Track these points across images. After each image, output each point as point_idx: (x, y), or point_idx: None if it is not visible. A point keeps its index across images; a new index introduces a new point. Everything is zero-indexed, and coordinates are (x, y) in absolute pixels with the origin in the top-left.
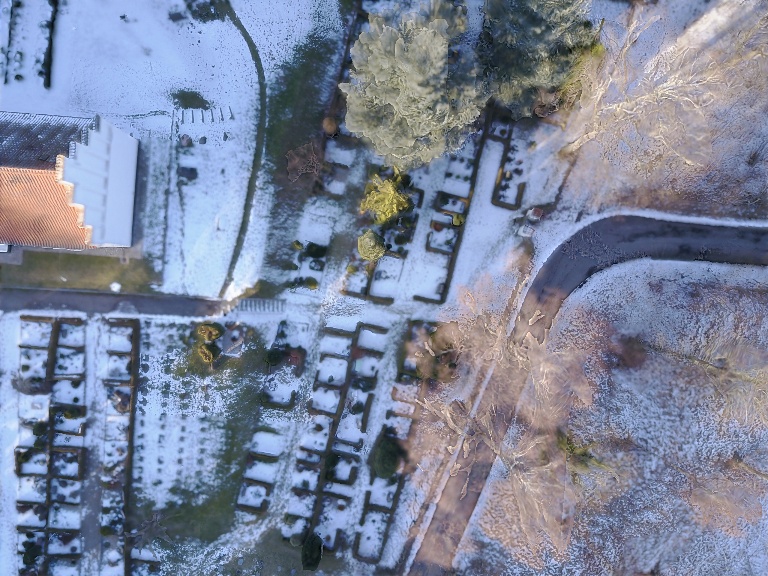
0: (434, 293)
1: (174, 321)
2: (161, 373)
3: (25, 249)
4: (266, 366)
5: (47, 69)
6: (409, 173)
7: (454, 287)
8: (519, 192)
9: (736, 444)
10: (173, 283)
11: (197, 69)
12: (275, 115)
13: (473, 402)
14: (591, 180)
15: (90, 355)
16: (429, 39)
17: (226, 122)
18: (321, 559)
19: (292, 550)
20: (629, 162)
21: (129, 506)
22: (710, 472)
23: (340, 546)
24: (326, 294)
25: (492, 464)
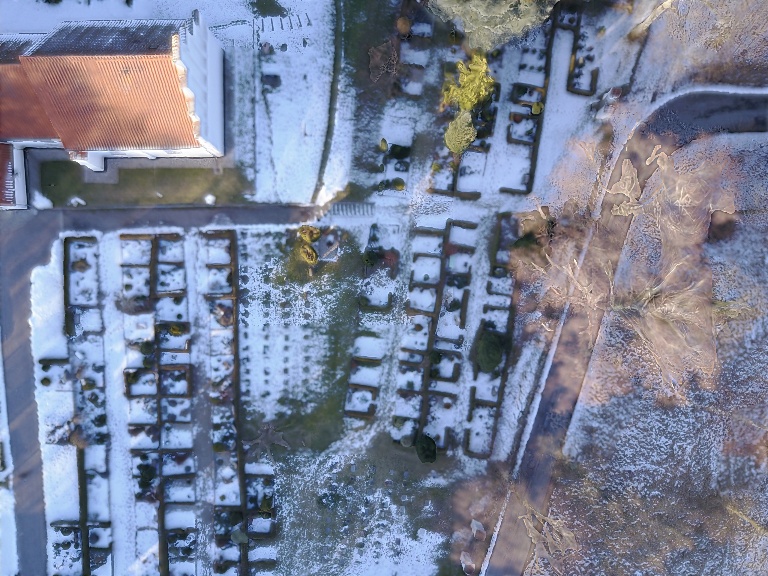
0: (519, 184)
1: (269, 230)
2: (261, 283)
3: (120, 167)
4: (362, 270)
5: None
6: None
7: (538, 176)
8: (593, 77)
9: None
10: (266, 192)
11: None
12: (351, 19)
13: (568, 288)
14: (662, 59)
15: (190, 271)
16: None
17: (304, 28)
18: None
19: (403, 452)
20: (698, 38)
21: (239, 420)
22: None
23: (450, 444)
24: (413, 194)
25: None
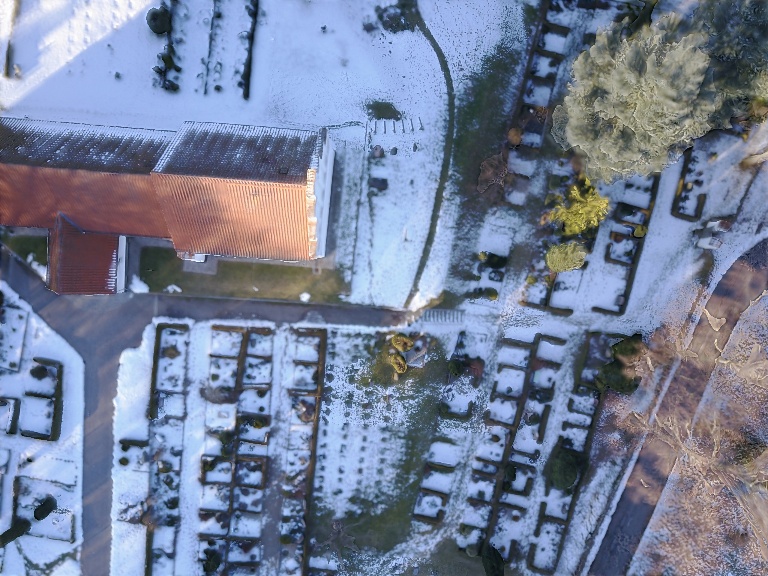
0: (612, 305)
1: (359, 331)
2: (345, 383)
3: (220, 259)
4: (446, 377)
5: (247, 80)
6: (593, 184)
7: (632, 299)
8: (700, 204)
9: None
10: (360, 293)
11: (390, 80)
12: (463, 126)
13: (650, 414)
14: None
15: (277, 364)
16: (689, 55)
17: (416, 133)
18: None
19: (467, 560)
20: None
21: (310, 515)
22: None
23: (514, 557)
24: (505, 305)
25: (668, 477)
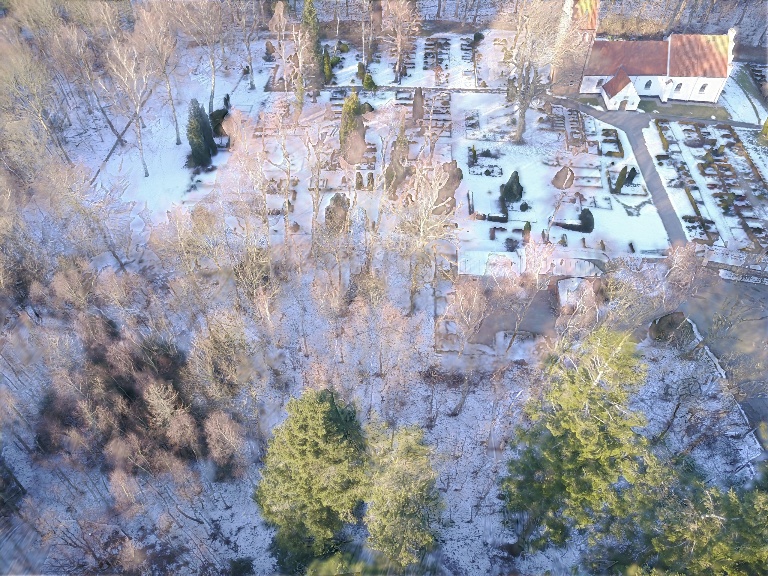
0: None
1: None
2: (750, 144)
3: None
4: None
5: None
6: None
7: None
8: None
9: None
10: None
11: None
12: None
13: None
14: None
15: None
16: None
17: None
18: None
19: None
20: None
21: None
22: None
23: None
24: None
25: None
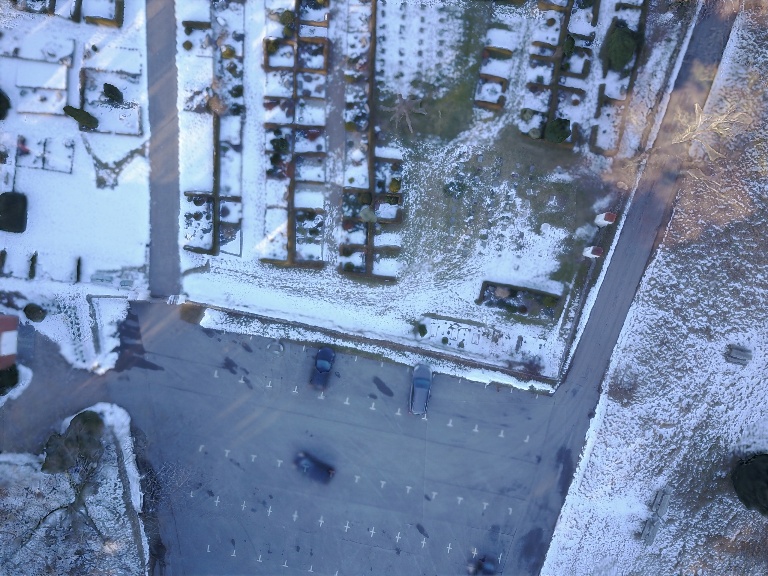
0: None
1: None
2: None
3: None
4: None
5: None
6: None
7: None
8: None
9: None
10: None
11: None
12: None
13: None
14: None
15: None
16: None
17: None
18: (559, 154)
19: (530, 146)
20: None
21: (373, 100)
22: None
23: (577, 141)
24: None
25: (723, 52)
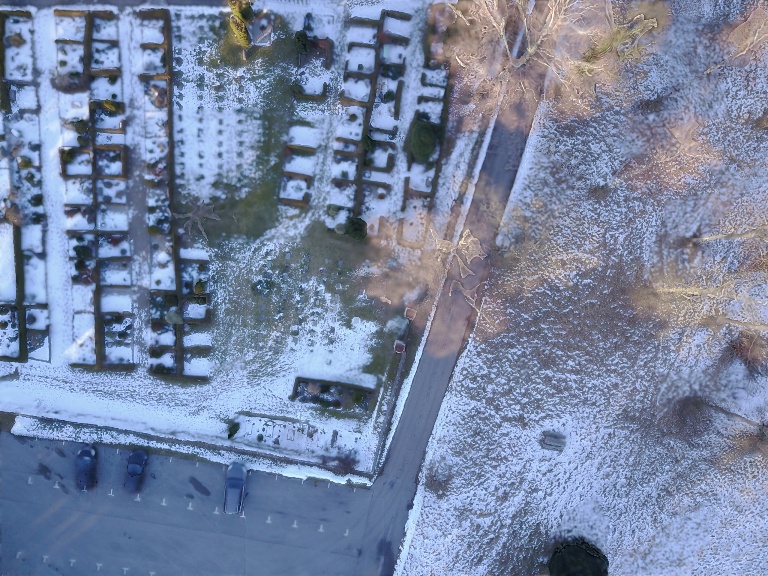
0: None
1: (203, 12)
2: (195, 66)
3: None
4: (296, 58)
5: None
6: None
7: None
8: None
9: (765, 101)
10: None
11: None
12: None
13: None
14: None
15: (124, 51)
16: None
17: None
18: (367, 248)
19: (337, 241)
20: None
21: (174, 203)
22: (742, 130)
23: (384, 234)
24: None
25: (526, 141)
